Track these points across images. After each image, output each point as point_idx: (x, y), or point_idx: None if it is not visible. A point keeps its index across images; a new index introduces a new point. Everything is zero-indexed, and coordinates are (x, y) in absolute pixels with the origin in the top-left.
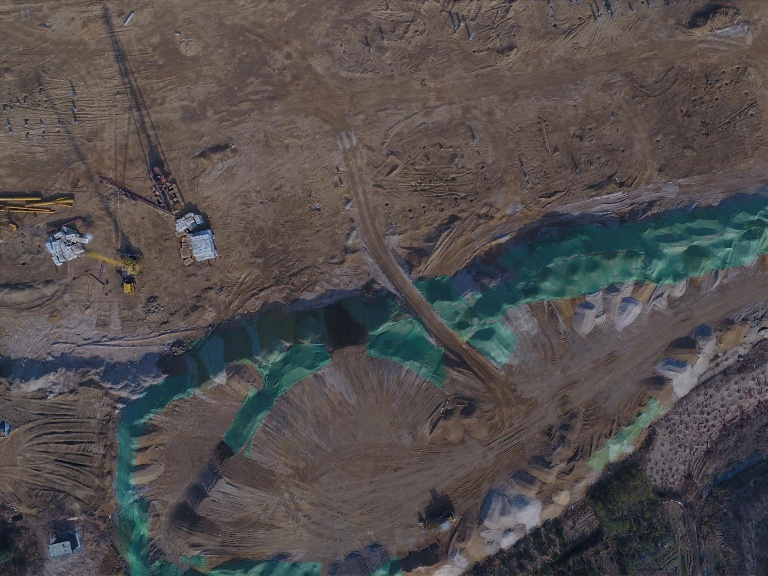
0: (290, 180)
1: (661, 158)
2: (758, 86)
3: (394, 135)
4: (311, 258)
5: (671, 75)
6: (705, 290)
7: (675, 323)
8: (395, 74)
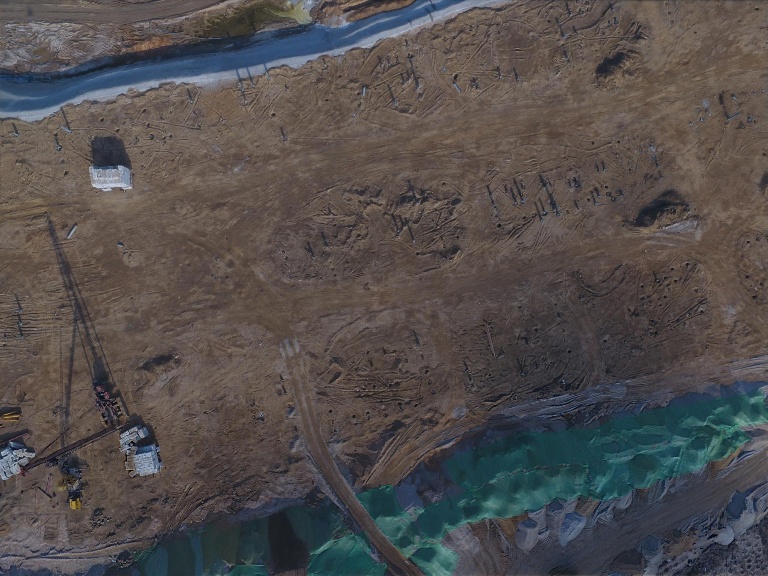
0: (234, 389)
1: (608, 359)
2: (708, 282)
3: (337, 341)
4: (255, 467)
5: (618, 273)
6: (652, 501)
7: (621, 535)
8: (338, 279)
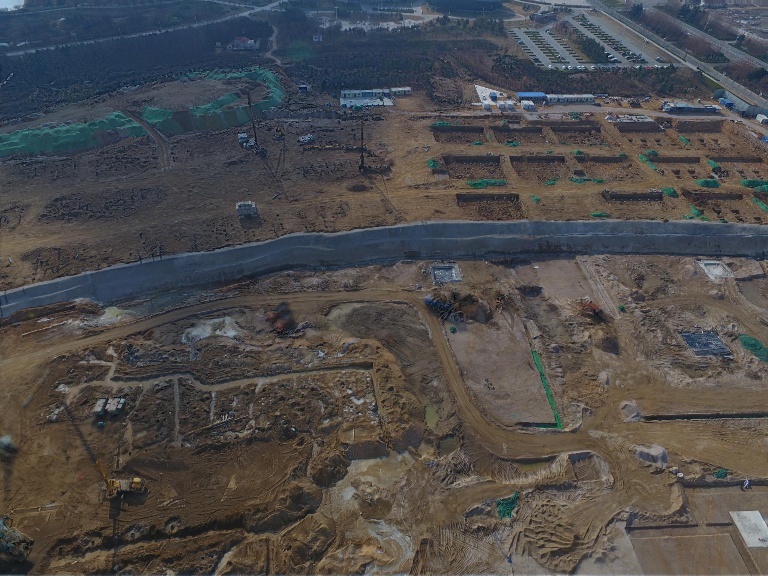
0: None
1: None
2: None
3: None
4: None
5: None
6: (5, 132)
7: None
8: None
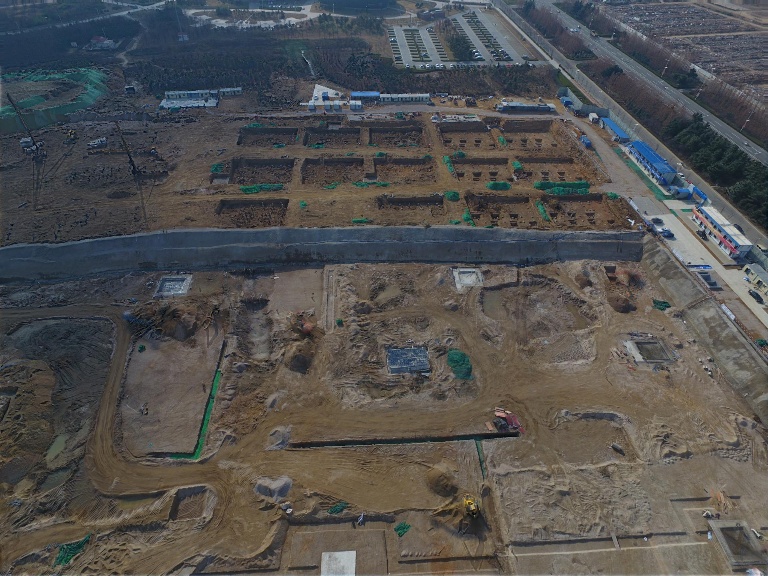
0: None
1: None
2: None
3: None
4: None
5: None
6: None
7: None
8: None
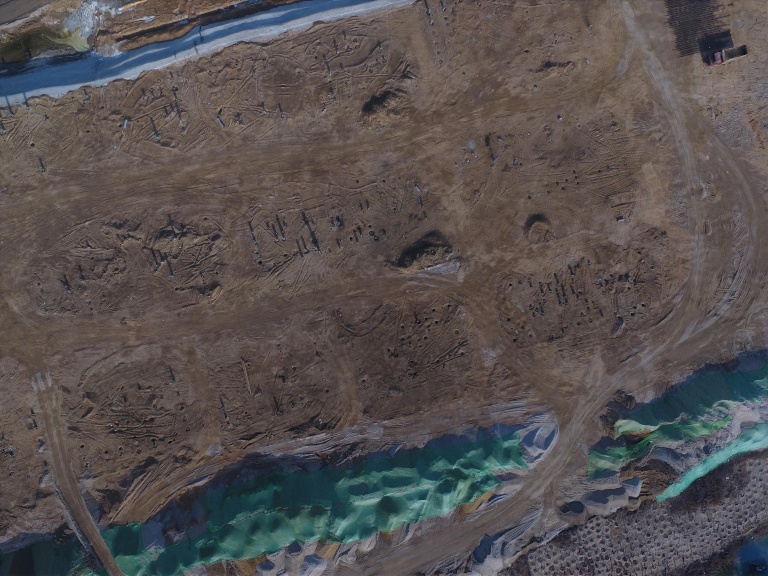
0: None
1: (366, 399)
2: (469, 324)
3: (91, 376)
4: (3, 502)
5: (379, 313)
6: (396, 544)
7: None
8: (94, 313)
